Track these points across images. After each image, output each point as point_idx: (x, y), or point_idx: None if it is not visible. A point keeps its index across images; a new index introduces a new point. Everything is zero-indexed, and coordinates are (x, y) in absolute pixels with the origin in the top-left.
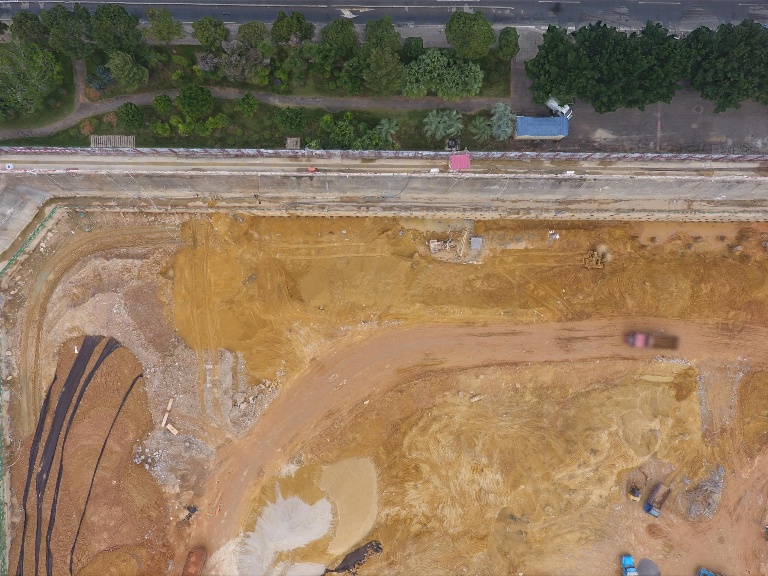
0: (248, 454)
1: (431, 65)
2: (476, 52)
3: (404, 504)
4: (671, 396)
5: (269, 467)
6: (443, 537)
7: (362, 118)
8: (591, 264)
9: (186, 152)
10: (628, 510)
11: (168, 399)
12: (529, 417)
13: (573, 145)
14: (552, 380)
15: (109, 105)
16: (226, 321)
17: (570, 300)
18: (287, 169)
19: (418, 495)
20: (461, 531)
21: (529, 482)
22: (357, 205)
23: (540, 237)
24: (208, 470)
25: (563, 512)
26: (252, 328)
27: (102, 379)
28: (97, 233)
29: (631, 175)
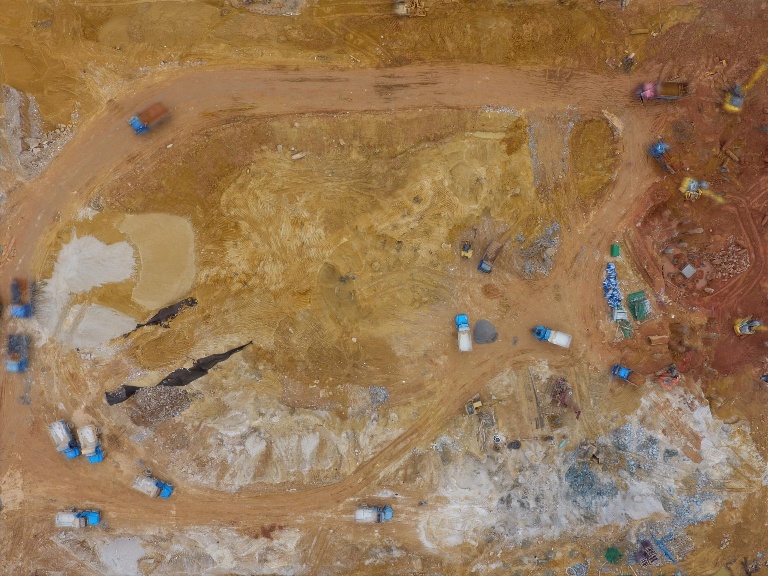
0: (41, 197)
1: None
2: None
3: (223, 263)
4: (502, 151)
5: (65, 211)
6: (264, 294)
7: None
8: (413, 12)
9: None
10: (463, 271)
11: None
12: (357, 177)
13: None
14: (377, 136)
15: None
16: (12, 59)
17: (389, 46)
18: None
19: (238, 253)
20: (283, 287)
21: (356, 240)
22: None
23: None
24: None
25: (392, 269)
26: (43, 68)
27: None
28: None
29: None
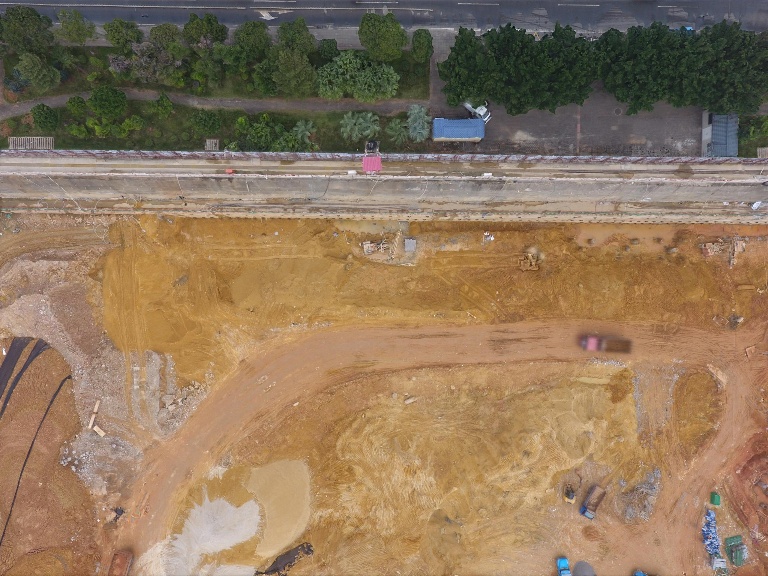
0: (176, 456)
1: (343, 67)
2: (387, 54)
3: (337, 506)
4: (607, 398)
5: (197, 469)
6: (375, 539)
7: (281, 120)
8: (526, 266)
9: (104, 154)
10: (564, 512)
11: (95, 401)
12: (465, 419)
13: (493, 147)
14: (487, 382)
15: (28, 107)
16: (154, 323)
17: (504, 302)
18: (206, 171)
19: (351, 497)
20: (394, 533)
21: (463, 484)
22: (283, 207)
23: (475, 239)
24: (135, 472)
25: (497, 514)
26: (181, 330)
27: (30, 381)
28: (25, 235)
29: (550, 177)
